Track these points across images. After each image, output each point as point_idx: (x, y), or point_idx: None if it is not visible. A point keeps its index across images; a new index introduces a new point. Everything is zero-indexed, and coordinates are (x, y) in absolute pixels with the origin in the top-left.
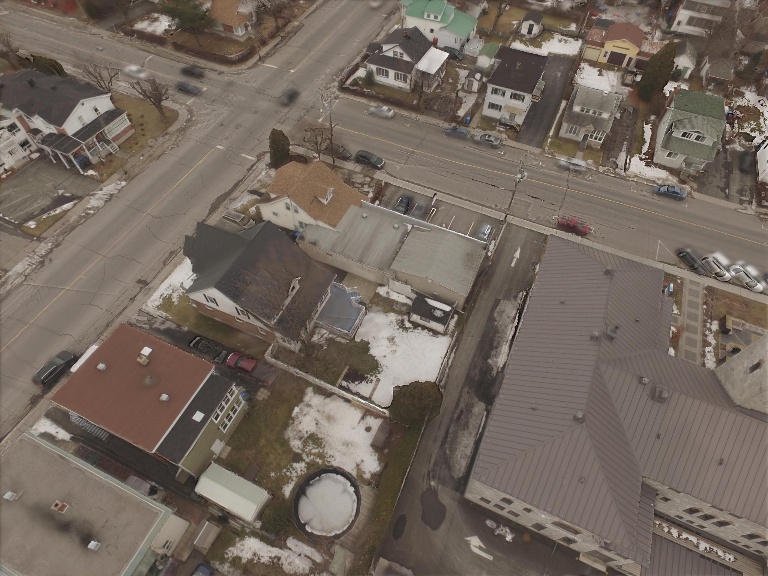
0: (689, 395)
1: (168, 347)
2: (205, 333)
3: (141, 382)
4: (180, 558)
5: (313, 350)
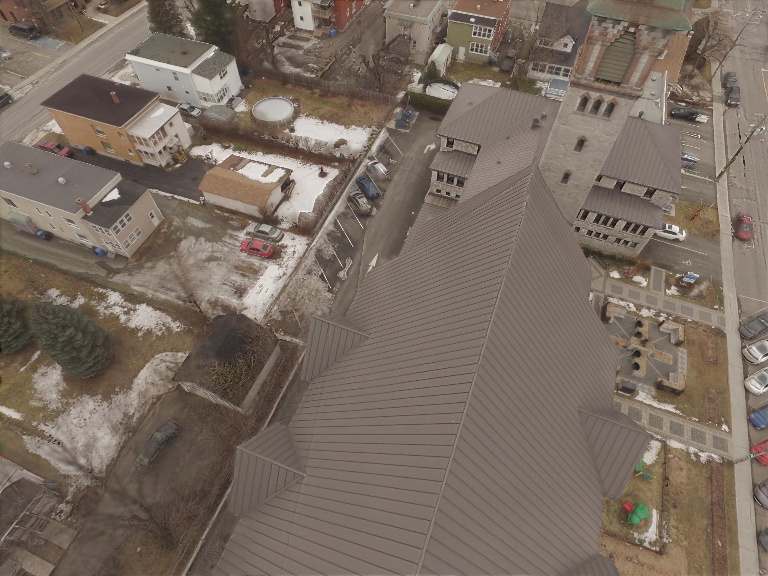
0: (541, 134)
1: (506, 5)
2: (526, 45)
3: (484, 2)
4: (410, 57)
5: (531, 83)
